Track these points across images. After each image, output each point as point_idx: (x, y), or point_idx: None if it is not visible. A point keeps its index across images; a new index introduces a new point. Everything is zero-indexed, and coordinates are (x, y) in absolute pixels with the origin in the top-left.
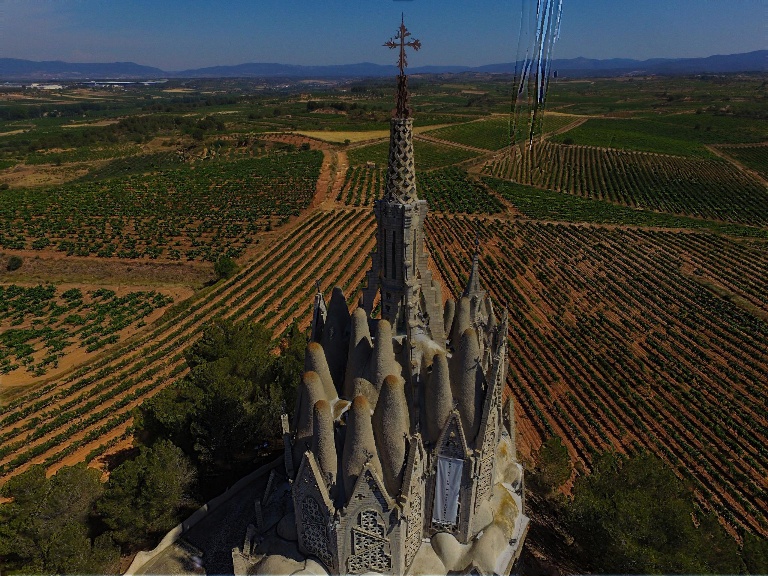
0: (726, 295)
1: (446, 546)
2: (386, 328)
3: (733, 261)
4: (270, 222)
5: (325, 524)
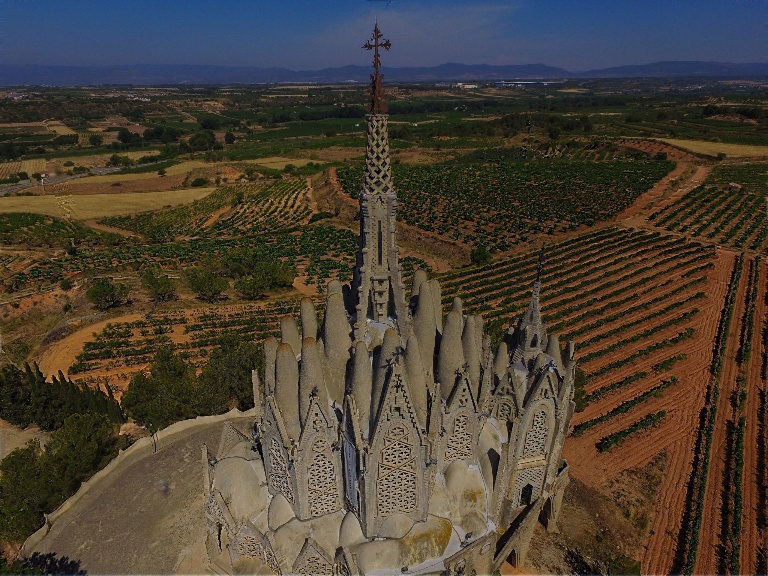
0: None
1: (346, 524)
2: (333, 300)
3: None
4: (556, 226)
5: None
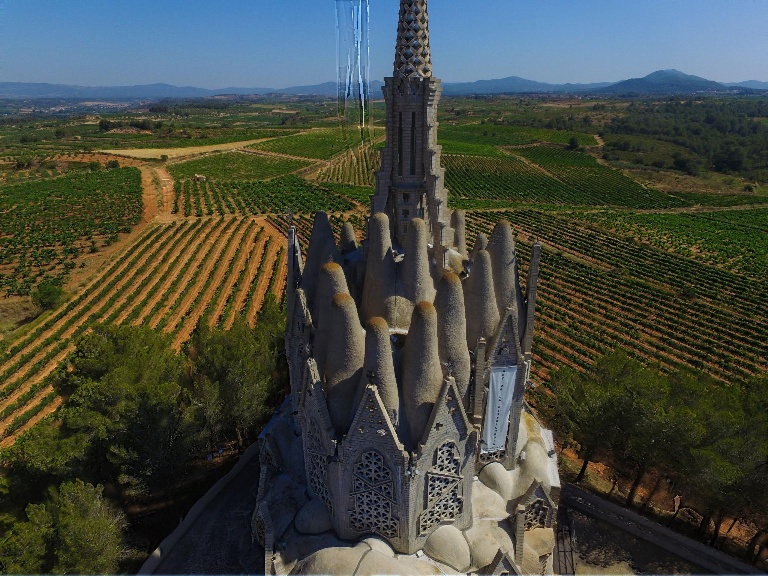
0: (558, 252)
1: (499, 475)
2: (424, 225)
3: (551, 228)
4: (94, 242)
5: (392, 479)
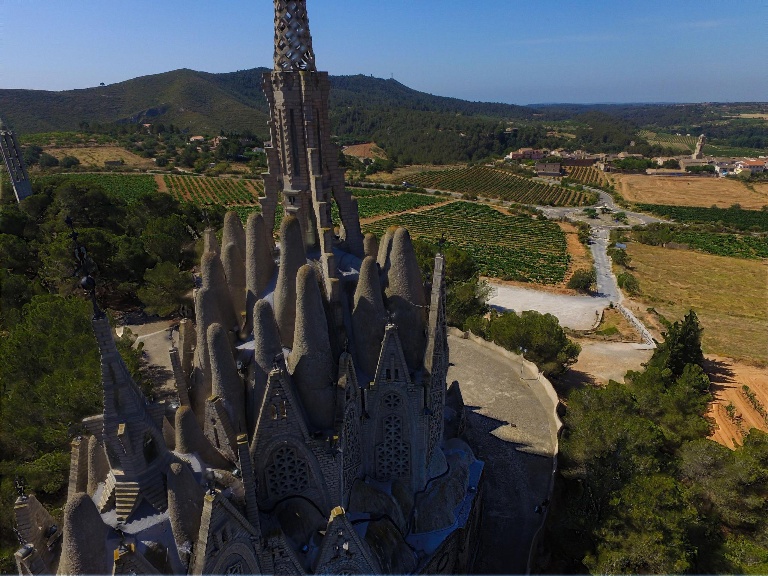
0: None
1: None
2: None
3: None
4: None
5: None
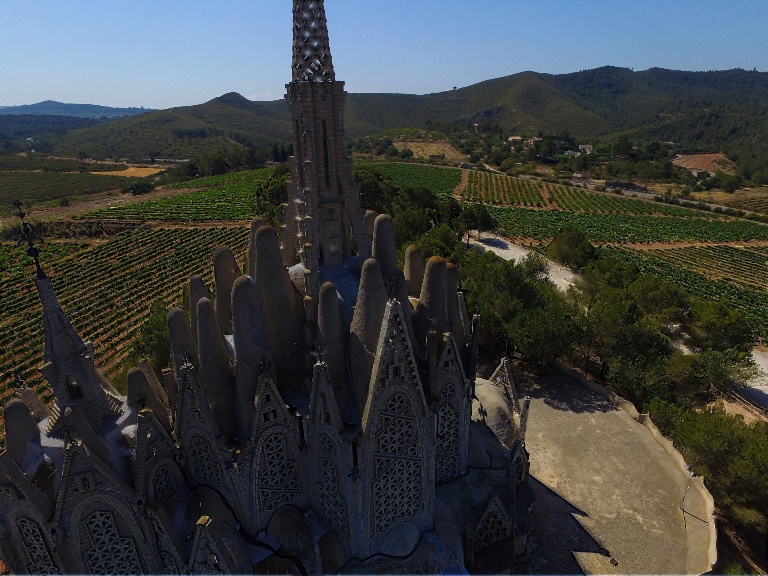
0: None
1: None
2: None
3: None
4: None
5: None
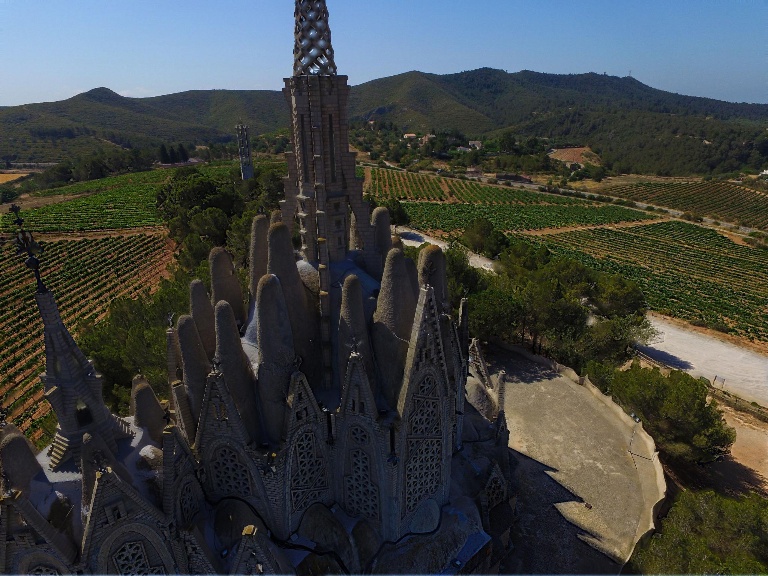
0: None
1: None
2: None
3: None
4: None
5: None
